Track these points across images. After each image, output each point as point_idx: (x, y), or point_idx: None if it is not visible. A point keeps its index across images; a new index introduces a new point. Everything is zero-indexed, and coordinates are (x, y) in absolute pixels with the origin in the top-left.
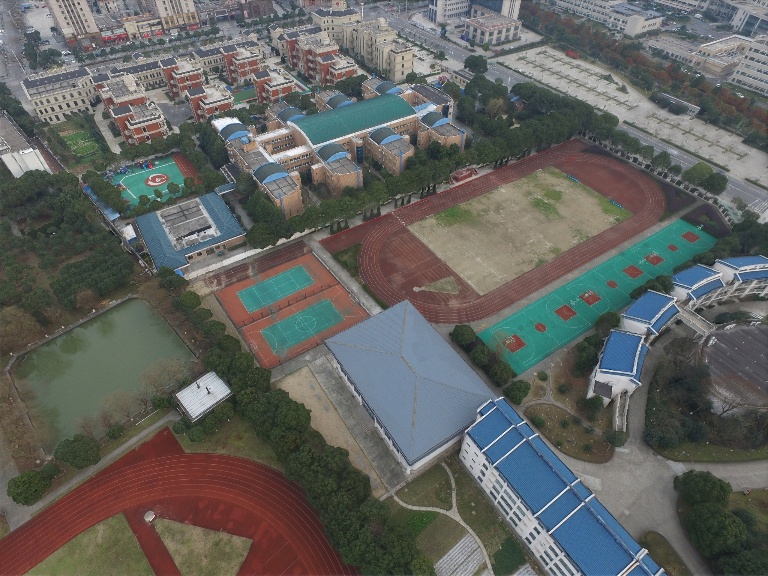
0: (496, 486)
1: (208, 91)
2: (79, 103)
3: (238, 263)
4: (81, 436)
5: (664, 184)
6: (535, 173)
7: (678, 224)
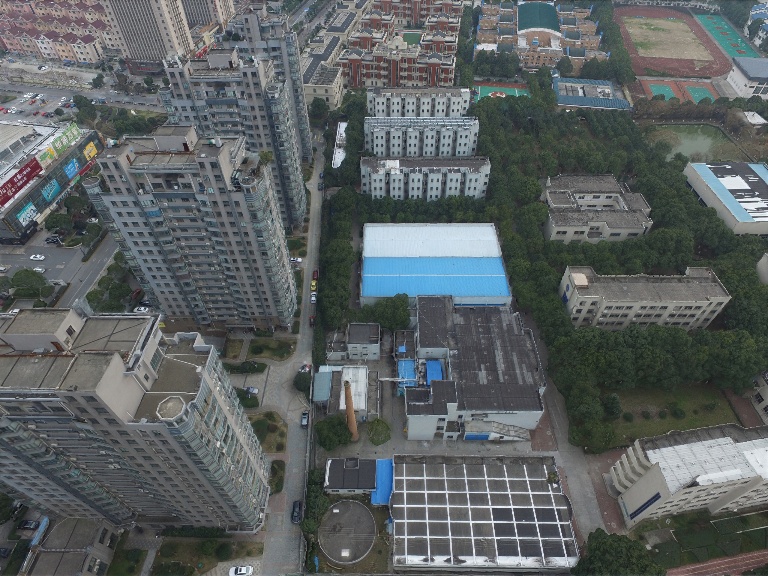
0: None
1: None
2: (341, 85)
3: None
4: None
5: (667, 6)
6: (624, 21)
7: (699, 16)
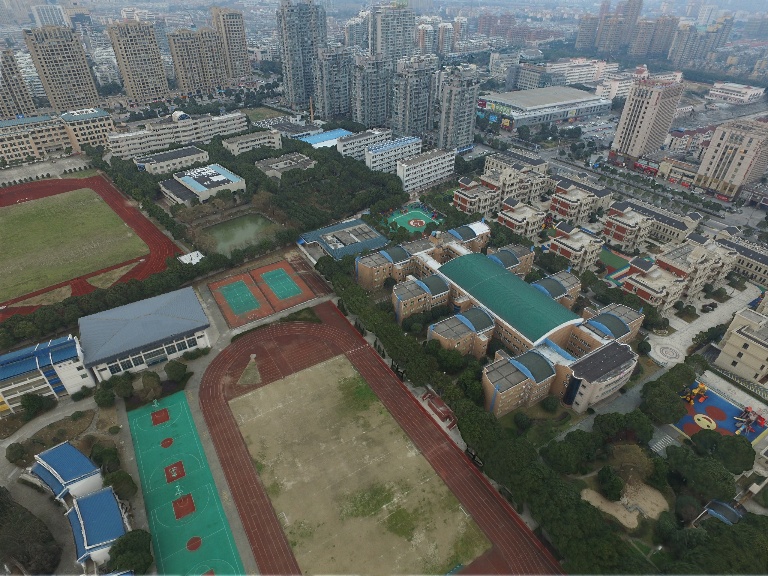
0: None
1: (522, 209)
2: None
3: (313, 266)
4: (182, 227)
5: None
6: None
7: None
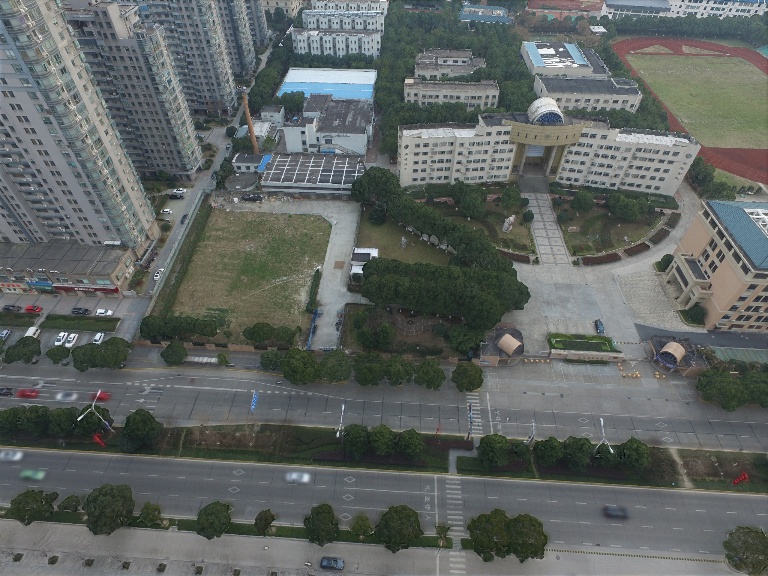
0: (685, 10)
1: None
2: (300, 4)
3: None
4: None
5: None
6: None
7: None
